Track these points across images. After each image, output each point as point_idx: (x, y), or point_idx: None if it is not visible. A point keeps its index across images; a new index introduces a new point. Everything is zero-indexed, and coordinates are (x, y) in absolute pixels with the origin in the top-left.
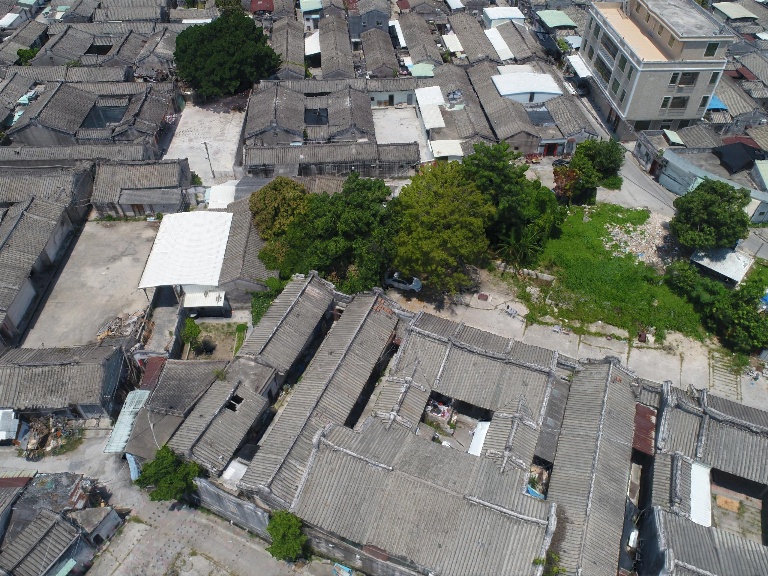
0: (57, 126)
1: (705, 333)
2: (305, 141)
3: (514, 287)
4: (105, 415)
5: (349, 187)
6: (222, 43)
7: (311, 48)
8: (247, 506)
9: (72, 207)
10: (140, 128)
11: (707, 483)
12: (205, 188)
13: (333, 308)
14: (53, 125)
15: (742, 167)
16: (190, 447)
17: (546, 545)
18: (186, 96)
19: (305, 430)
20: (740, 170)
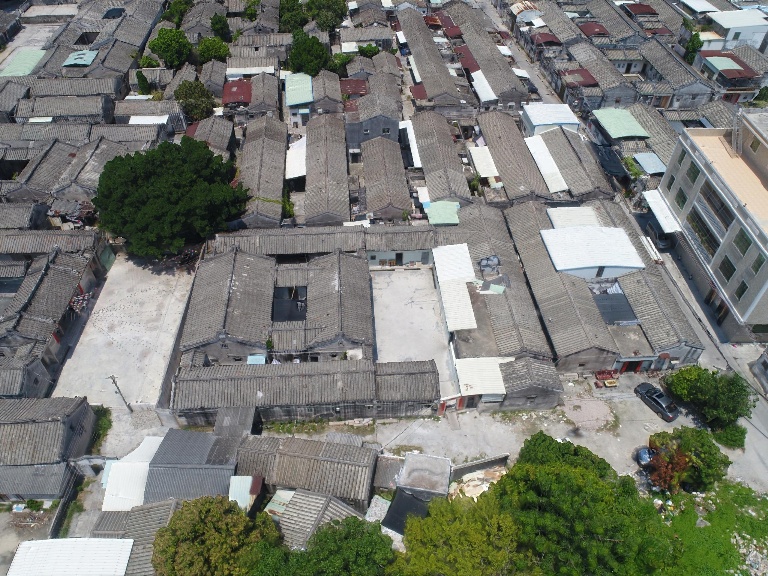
0: None
1: None
2: (269, 353)
3: None
4: None
5: (316, 569)
6: (160, 188)
7: (294, 167)
8: None
9: None
10: (25, 333)
11: None
12: (104, 459)
13: None
14: None
15: None
16: None
17: None
18: (116, 246)
19: None
20: None
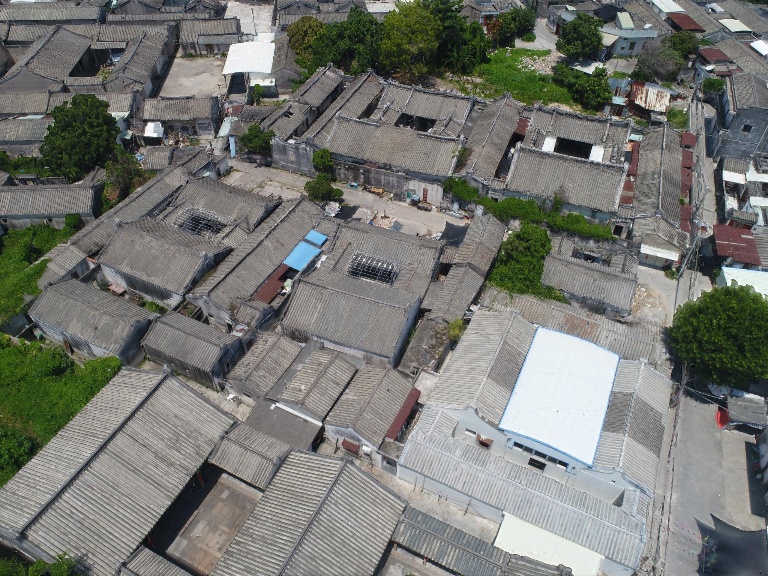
0: (147, 3)
1: (574, 104)
2: None
3: (457, 86)
4: (211, 132)
5: (351, 14)
6: None
7: None
8: (301, 146)
9: (168, 44)
10: (205, 4)
11: (553, 144)
12: (254, 36)
13: (342, 88)
14: (145, 2)
15: (609, 18)
16: (267, 125)
17: (459, 149)
18: None
19: (330, 122)
20: (609, 22)
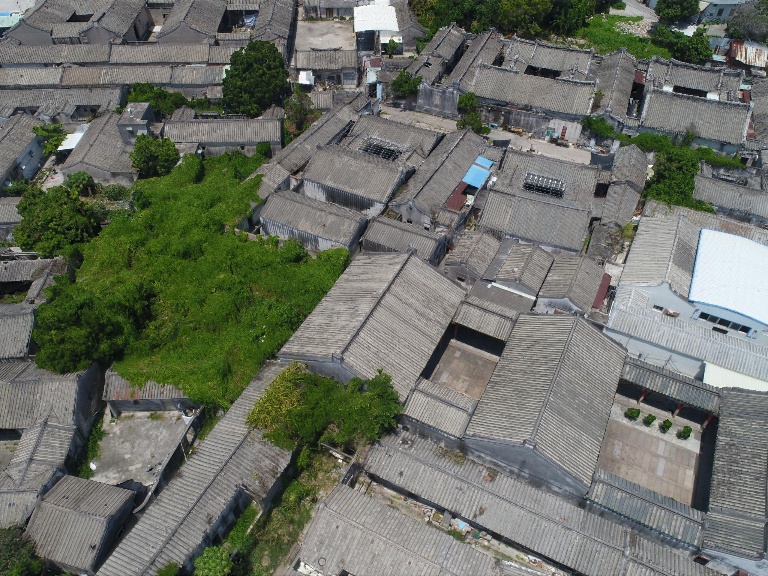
0: None
1: None
2: None
3: None
4: (353, 82)
5: None
6: None
7: None
8: (449, 90)
9: (294, 7)
10: None
11: None
12: (369, 1)
13: (464, 45)
14: None
15: None
16: (415, 73)
17: (595, 91)
18: None
19: (468, 71)
20: None
